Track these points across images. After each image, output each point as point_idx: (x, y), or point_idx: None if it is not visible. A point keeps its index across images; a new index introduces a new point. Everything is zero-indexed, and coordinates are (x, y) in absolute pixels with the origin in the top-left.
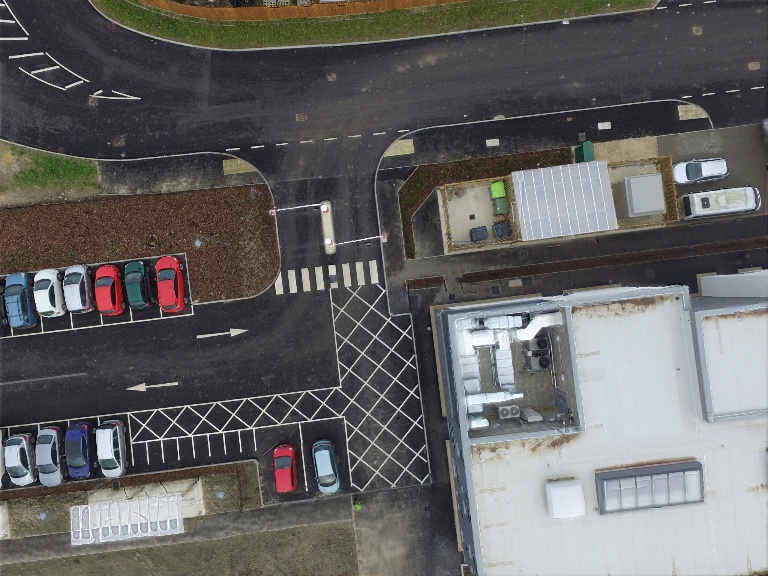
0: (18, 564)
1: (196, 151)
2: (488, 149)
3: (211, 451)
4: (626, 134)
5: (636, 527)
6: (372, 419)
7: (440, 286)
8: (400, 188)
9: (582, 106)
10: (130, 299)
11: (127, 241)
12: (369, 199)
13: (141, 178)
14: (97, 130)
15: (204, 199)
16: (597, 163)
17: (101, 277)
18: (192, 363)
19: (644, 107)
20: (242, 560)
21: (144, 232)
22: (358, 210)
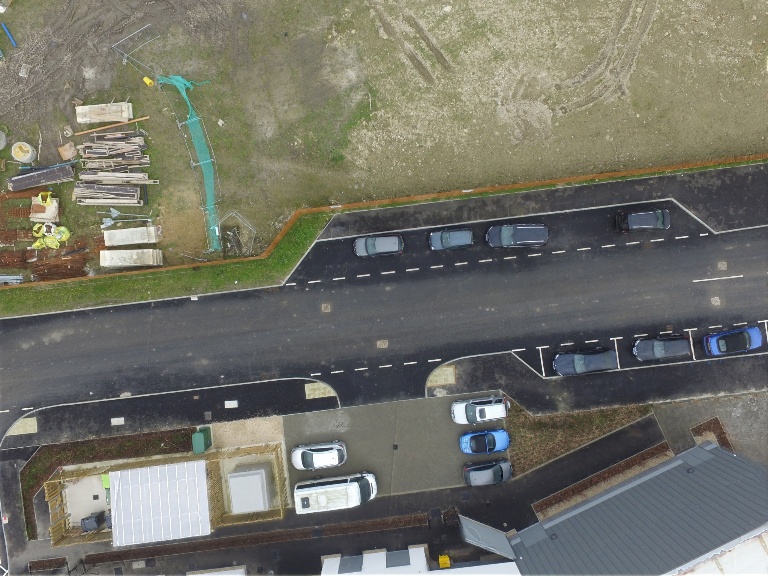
0: None
1: None
2: (113, 428)
3: None
4: (252, 413)
5: None
6: None
7: (63, 567)
8: (22, 468)
9: (210, 383)
10: None
11: None
12: None
13: None
14: None
15: None
16: (195, 463)
17: None
18: None
19: (272, 385)
20: None
21: None
22: None
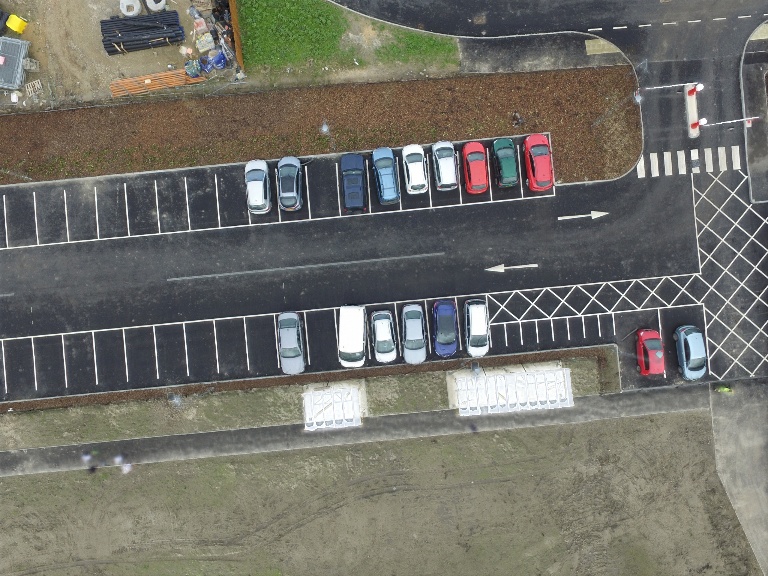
0: (375, 443)
1: (558, 30)
2: None
3: (570, 334)
4: None
5: None
6: (731, 307)
7: None
8: (766, 72)
9: None
10: (505, 174)
11: (490, 119)
12: (733, 83)
13: (503, 56)
14: (458, 7)
15: (568, 78)
16: None
17: (472, 152)
18: (552, 245)
19: None
20: (600, 445)
21: (507, 110)
22: (722, 94)
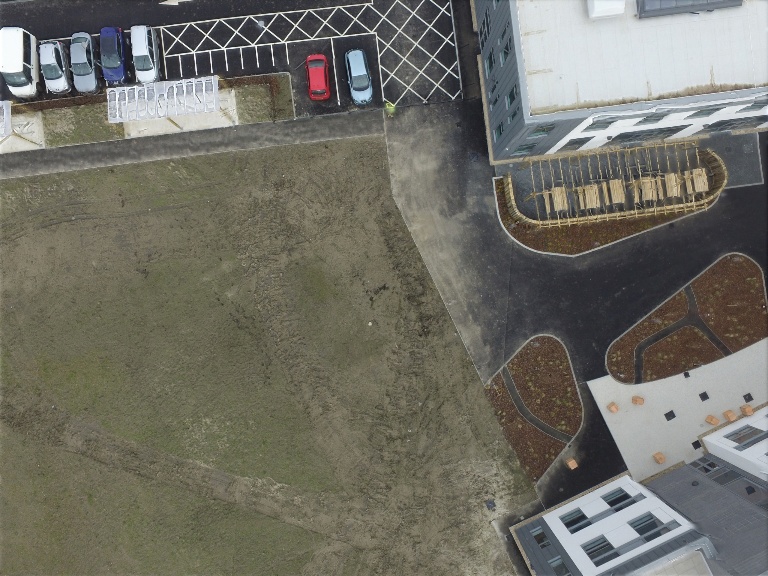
0: (53, 174)
1: None
2: None
3: (244, 64)
4: None
5: (675, 34)
6: (404, 36)
7: None
8: None
9: None
10: None
11: None
12: None
13: None
14: None
15: None
16: None
17: None
18: None
19: None
20: (275, 171)
21: None
22: None
